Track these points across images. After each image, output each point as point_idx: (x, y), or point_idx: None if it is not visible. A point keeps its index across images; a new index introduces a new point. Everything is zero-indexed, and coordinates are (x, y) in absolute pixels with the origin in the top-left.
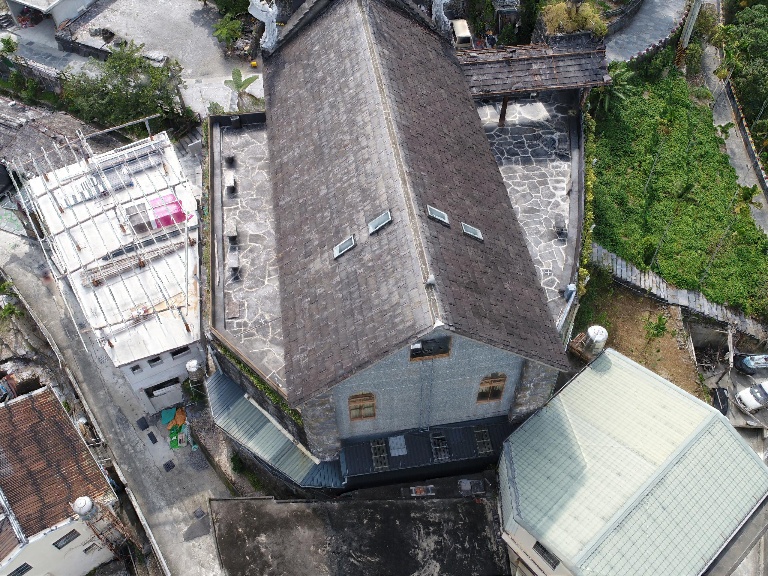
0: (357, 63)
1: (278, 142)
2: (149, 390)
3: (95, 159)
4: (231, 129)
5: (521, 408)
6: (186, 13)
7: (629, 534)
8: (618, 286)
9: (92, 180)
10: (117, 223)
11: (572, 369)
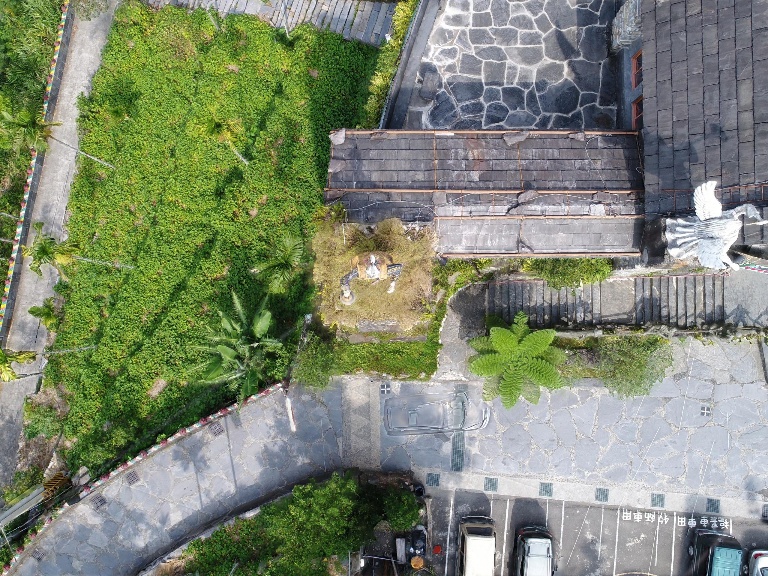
0: None
1: None
2: None
3: None
4: None
5: None
6: None
7: None
8: None
9: None
10: None
11: None
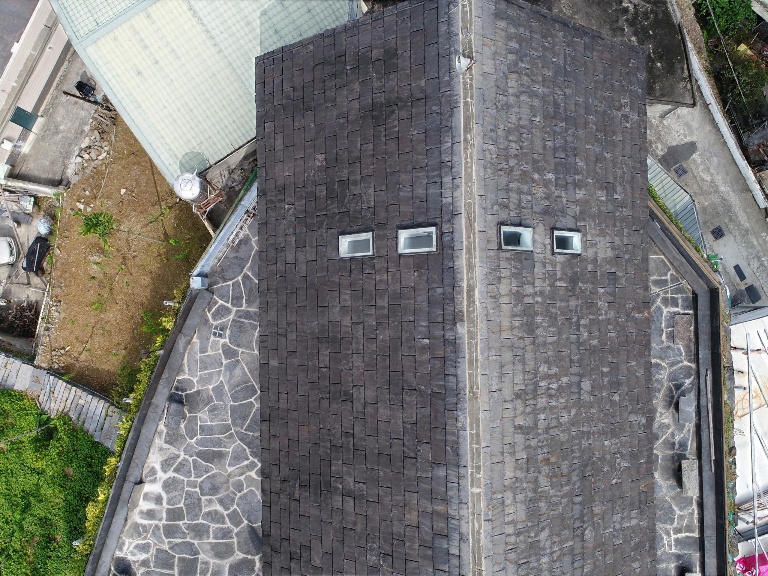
0: None
1: (644, 571)
2: None
3: None
4: None
5: None
6: None
7: None
8: (108, 397)
9: None
10: None
11: (226, 209)
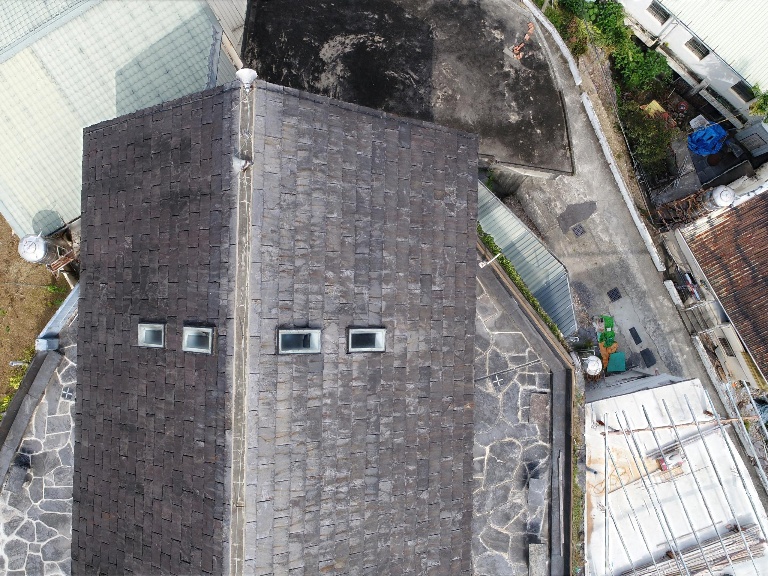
0: None
1: None
2: None
3: None
4: None
5: None
6: None
7: None
8: None
9: None
10: None
11: None
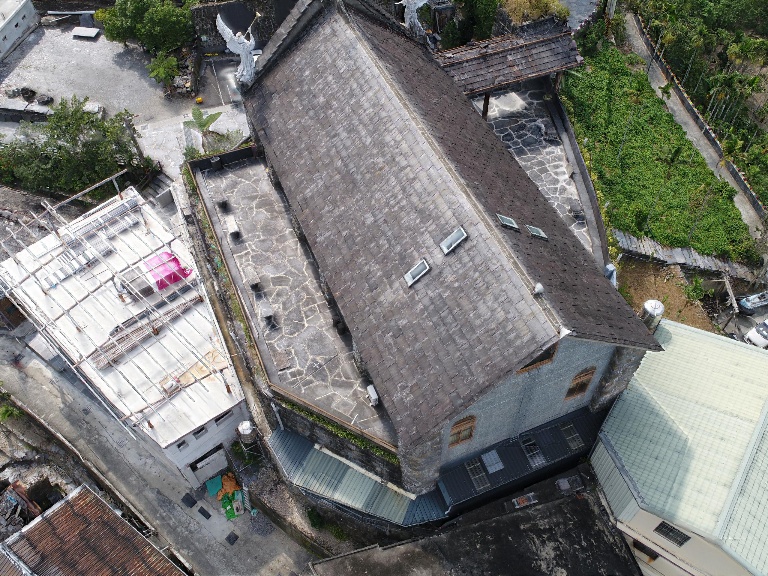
0: (365, 82)
1: (292, 177)
2: (192, 464)
3: (64, 230)
4: (212, 172)
5: (606, 396)
6: (108, 58)
7: (753, 495)
8: None
9: (70, 253)
10: None
11: None
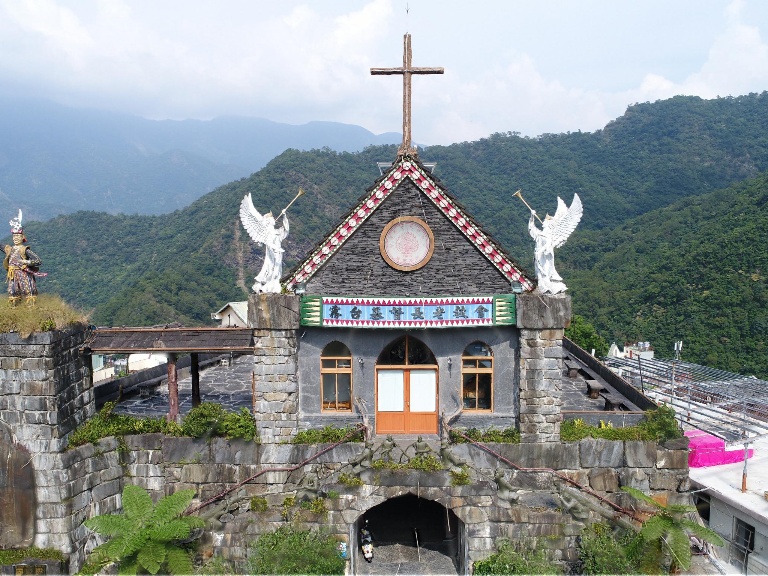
0: None
1: None
2: None
3: None
4: None
5: None
6: None
7: None
8: None
9: None
10: (764, 453)
11: None
